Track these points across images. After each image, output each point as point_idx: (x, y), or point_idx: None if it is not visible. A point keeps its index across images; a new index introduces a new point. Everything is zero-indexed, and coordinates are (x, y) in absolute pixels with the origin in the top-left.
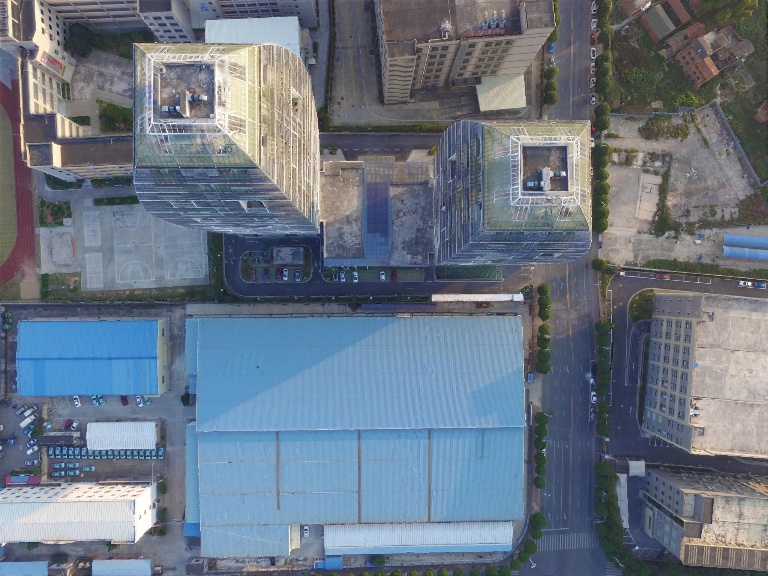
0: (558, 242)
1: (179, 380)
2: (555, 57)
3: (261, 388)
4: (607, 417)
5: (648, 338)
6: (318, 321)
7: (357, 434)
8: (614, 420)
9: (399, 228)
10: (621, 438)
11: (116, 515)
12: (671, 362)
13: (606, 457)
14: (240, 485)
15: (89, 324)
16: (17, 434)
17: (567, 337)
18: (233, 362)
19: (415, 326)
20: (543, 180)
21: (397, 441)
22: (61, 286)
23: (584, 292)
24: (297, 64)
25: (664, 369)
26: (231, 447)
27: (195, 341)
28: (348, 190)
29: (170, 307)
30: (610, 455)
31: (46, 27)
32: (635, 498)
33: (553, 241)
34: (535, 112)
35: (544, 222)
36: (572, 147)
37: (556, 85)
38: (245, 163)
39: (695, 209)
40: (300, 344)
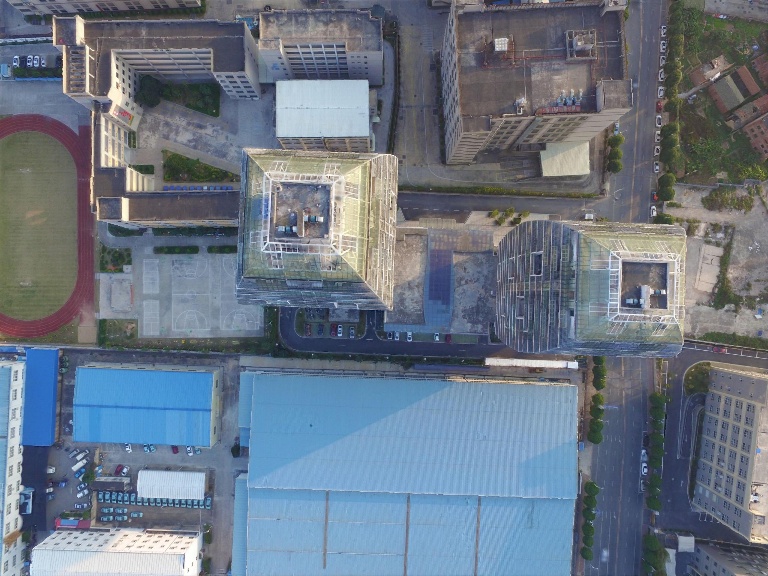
0: (647, 351)
1: (229, 431)
2: (620, 123)
3: (313, 447)
4: (659, 492)
5: (703, 412)
6: (373, 382)
7: (407, 497)
8: (664, 493)
9: (461, 296)
10: (671, 511)
11: (166, 568)
12: (729, 442)
13: (655, 531)
14: (288, 542)
15: (145, 373)
16: (68, 477)
17: (620, 406)
18: (287, 419)
19: (469, 391)
20: (642, 297)
21: (446, 506)
22: (118, 332)
23: (639, 362)
24: (395, 165)
25: (720, 447)
26: (281, 504)
27: (249, 395)
28: (411, 256)
29: (224, 357)
30: (659, 528)
31: (120, 81)
32: (682, 573)
33: (642, 350)
34: (597, 178)
35: (638, 336)
36: (673, 265)
37: (621, 154)
38: (352, 278)
39: (756, 283)
40: (354, 404)
